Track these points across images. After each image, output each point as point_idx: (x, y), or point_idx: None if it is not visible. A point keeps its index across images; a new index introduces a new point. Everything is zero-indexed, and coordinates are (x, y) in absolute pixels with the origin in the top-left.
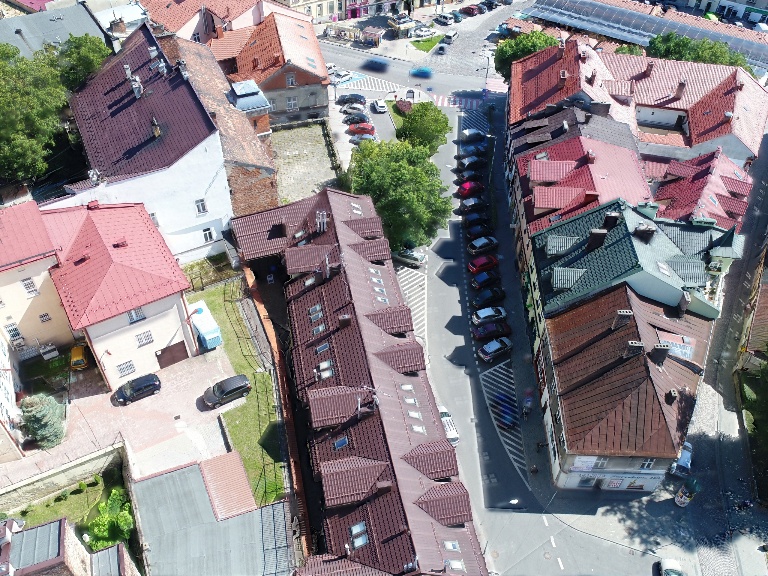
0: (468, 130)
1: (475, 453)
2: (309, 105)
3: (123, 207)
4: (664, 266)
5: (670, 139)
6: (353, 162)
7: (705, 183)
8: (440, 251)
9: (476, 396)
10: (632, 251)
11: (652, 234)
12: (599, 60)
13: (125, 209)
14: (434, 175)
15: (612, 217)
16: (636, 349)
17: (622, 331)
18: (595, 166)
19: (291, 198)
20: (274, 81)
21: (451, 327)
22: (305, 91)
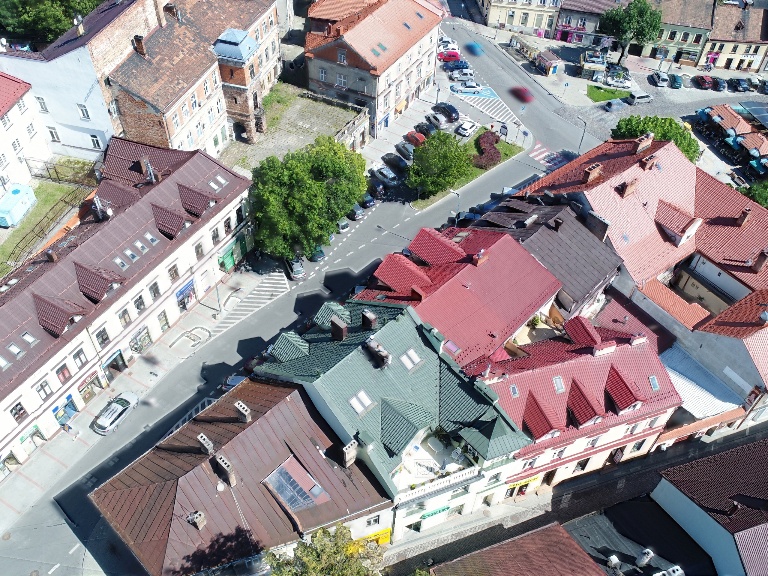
0: (511, 189)
1: (110, 452)
2: (358, 89)
3: (12, 79)
4: (368, 401)
5: (685, 309)
6: (303, 150)
7: (568, 359)
8: (331, 278)
9: (178, 411)
10: (338, 360)
11: (382, 359)
12: (691, 178)
13: (11, 82)
14: (337, 195)
15: (366, 316)
16: (204, 446)
17: (237, 426)
18: (476, 270)
19: (251, 159)
20: (327, 51)
21: (244, 344)
22: (355, 73)
